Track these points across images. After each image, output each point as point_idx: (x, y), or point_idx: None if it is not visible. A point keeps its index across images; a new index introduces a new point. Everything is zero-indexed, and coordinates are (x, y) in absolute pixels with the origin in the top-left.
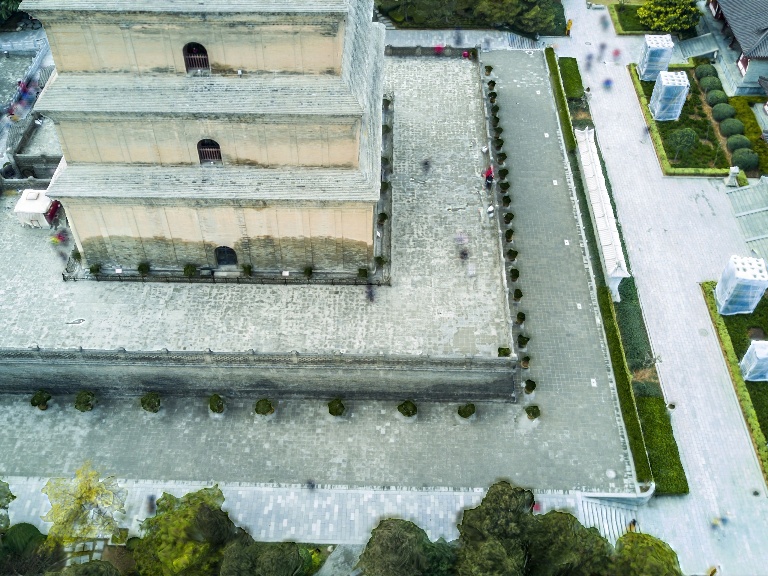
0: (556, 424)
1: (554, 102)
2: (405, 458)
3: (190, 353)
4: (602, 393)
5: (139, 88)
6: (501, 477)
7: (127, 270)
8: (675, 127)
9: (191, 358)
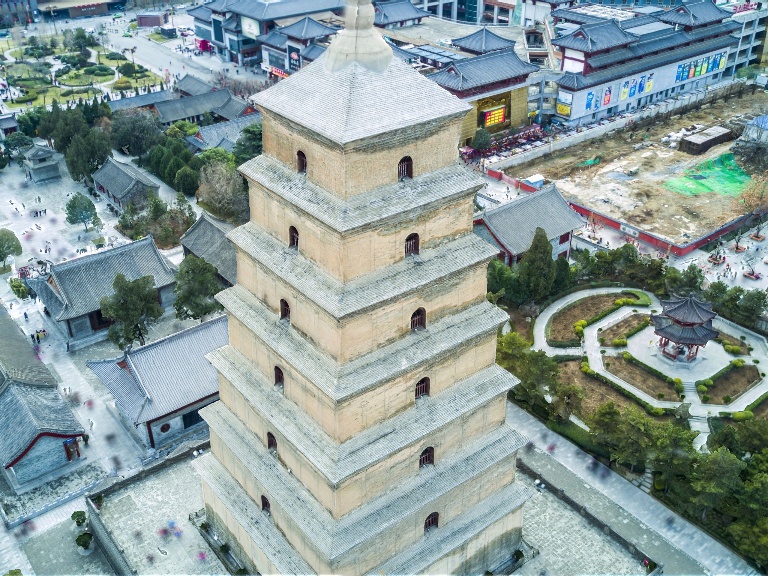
0: None
1: None
2: None
3: None
4: None
5: (244, 438)
6: None
7: (220, 541)
8: None
9: None
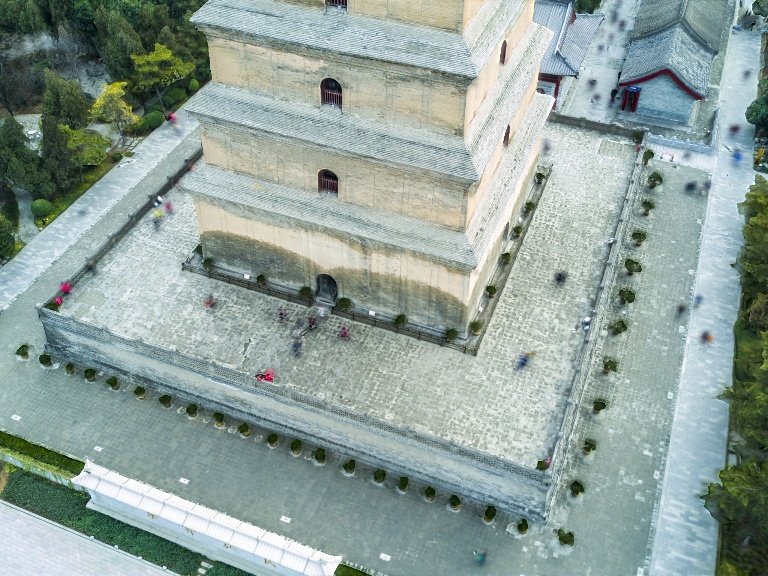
0: (7, 371)
1: None
2: (64, 276)
3: (194, 153)
4: (2, 418)
5: None
6: (2, 321)
7: None
8: None
9: (195, 158)
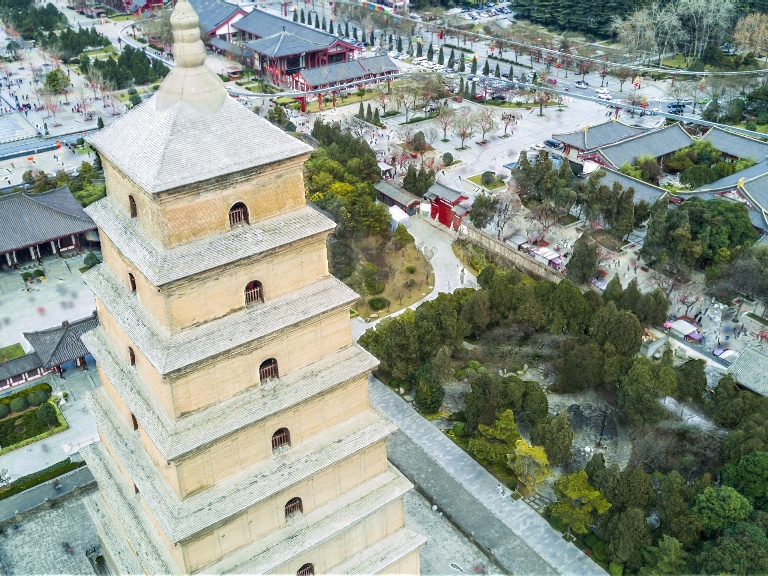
0: None
1: (6, 500)
2: None
3: None
4: None
5: None
6: None
7: None
8: (6, 439)
9: None
